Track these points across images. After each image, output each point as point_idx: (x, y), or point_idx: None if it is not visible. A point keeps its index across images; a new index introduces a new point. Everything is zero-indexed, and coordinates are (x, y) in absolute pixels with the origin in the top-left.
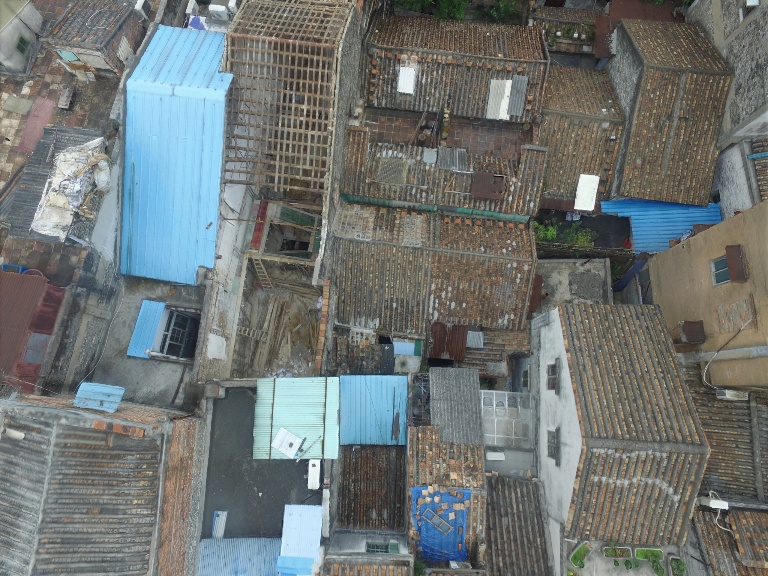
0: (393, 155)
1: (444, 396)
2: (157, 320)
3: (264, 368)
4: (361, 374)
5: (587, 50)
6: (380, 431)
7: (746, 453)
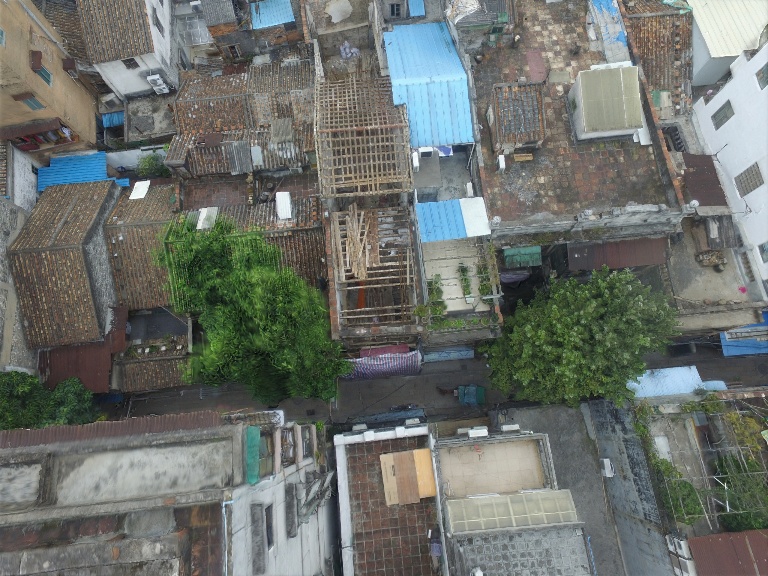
0: (286, 151)
1: (224, 4)
2: (411, 6)
3: (362, 56)
4: (290, 47)
5: (137, 341)
6: (266, 5)
7: (49, 20)
